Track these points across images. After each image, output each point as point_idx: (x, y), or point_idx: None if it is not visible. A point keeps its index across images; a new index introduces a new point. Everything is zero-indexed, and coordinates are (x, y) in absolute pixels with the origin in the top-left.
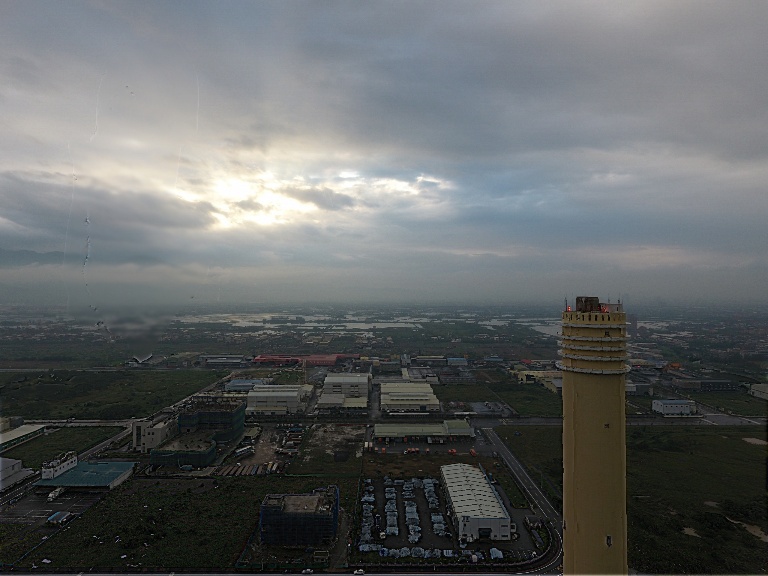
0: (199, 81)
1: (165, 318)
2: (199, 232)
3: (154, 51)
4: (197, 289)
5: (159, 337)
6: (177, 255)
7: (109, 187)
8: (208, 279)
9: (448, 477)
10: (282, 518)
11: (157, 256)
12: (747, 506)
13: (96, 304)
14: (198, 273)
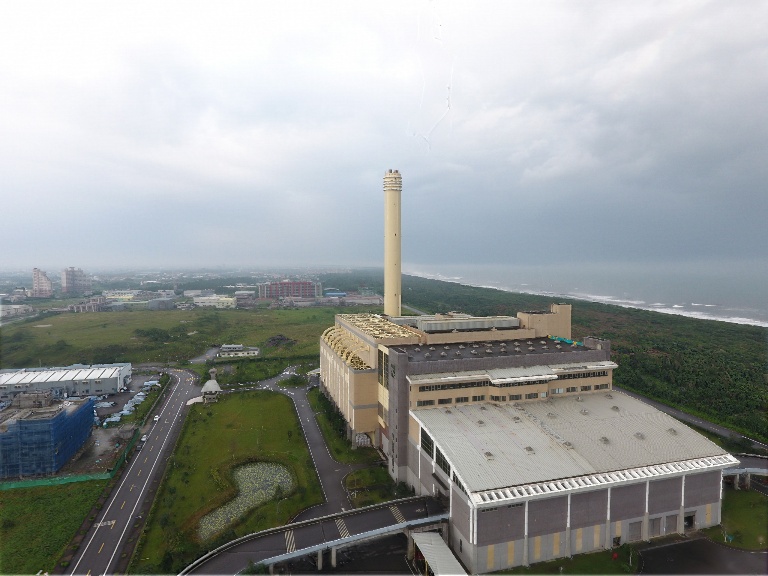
0: None
1: None
2: None
3: (426, 8)
4: (412, 131)
5: None
6: (418, 112)
7: (440, 72)
8: (406, 127)
9: (2, 382)
10: (65, 425)
11: (424, 111)
12: (154, 330)
13: None
14: (411, 123)
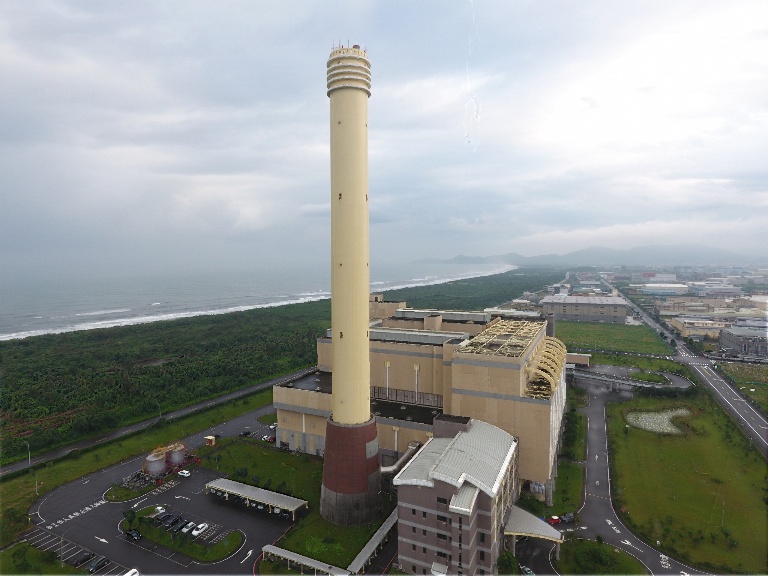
0: (468, 1)
1: (474, 133)
2: (465, 84)
3: None
4: None
5: (473, 143)
6: None
7: None
8: None
9: None
10: None
11: None
12: None
13: (467, 134)
14: None
